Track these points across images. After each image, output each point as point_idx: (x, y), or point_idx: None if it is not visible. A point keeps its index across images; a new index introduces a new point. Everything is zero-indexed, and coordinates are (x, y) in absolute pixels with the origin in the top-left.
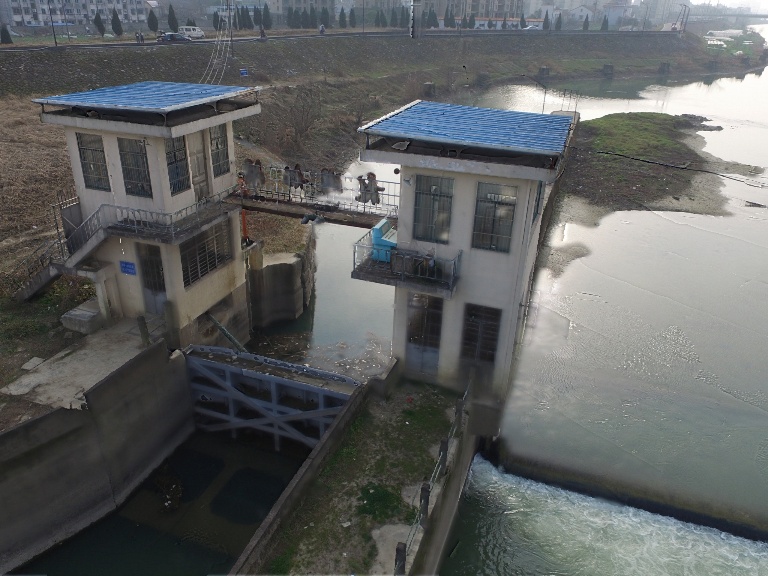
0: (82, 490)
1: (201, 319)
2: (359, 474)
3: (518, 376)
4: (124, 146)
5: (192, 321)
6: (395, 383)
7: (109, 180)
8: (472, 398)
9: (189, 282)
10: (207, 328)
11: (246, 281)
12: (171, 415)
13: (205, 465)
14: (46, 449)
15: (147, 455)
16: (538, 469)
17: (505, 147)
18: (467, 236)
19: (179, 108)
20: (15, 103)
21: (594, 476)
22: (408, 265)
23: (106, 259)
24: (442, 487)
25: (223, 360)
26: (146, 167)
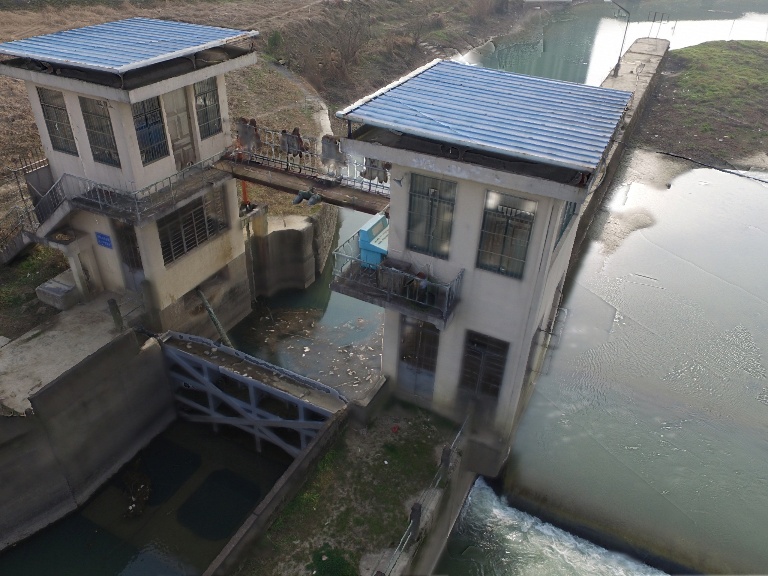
0: (34, 494)
1: (190, 295)
2: (316, 530)
3: (544, 378)
4: (86, 106)
5: (176, 300)
6: (383, 405)
7: (75, 143)
8: (469, 433)
9: (172, 258)
10: (196, 305)
11: (247, 249)
12: (145, 407)
13: (182, 460)
14: None
15: (115, 451)
16: (546, 506)
17: (520, 154)
18: (471, 253)
19: (139, 66)
20: (51, 17)
21: (611, 522)
22: (397, 281)
23: (82, 228)
24: (410, 558)
25: (201, 352)
26: (111, 132)
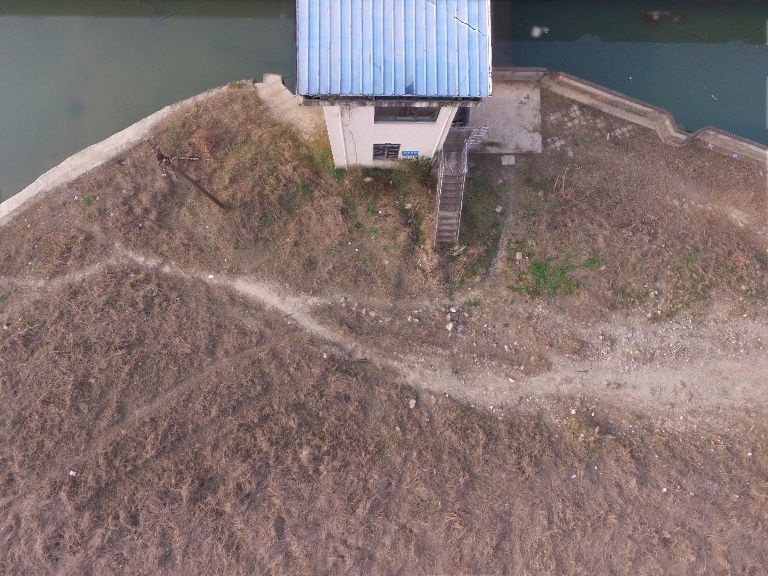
0: None
1: None
2: None
3: None
4: None
5: None
6: None
7: None
8: None
9: None
10: None
11: None
12: None
13: None
14: None
15: None
16: None
17: None
18: None
19: None
20: None
21: None
22: None
23: None
24: None
25: None
26: None
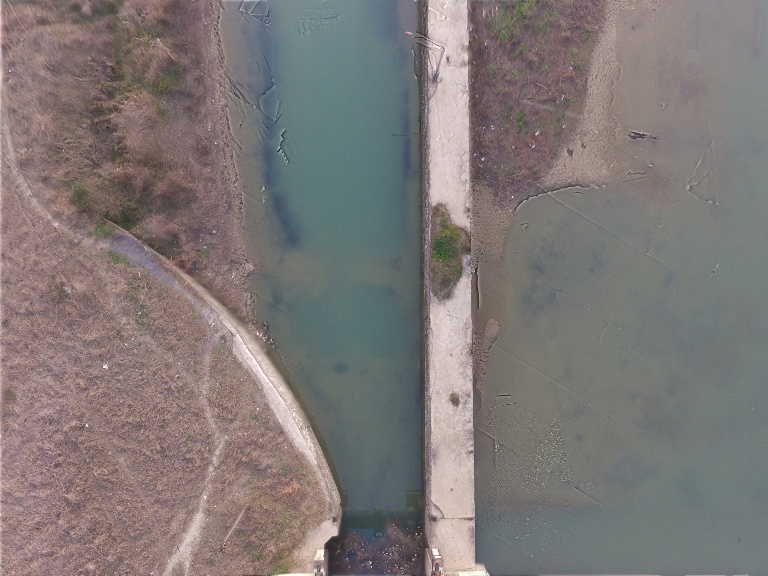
0: None
1: None
2: None
3: None
4: None
5: None
6: None
7: None
8: None
9: None
10: None
11: None
12: None
13: None
14: None
15: None
16: None
17: None
18: None
19: None
20: None
21: None
22: None
23: None
24: None
25: None
26: None
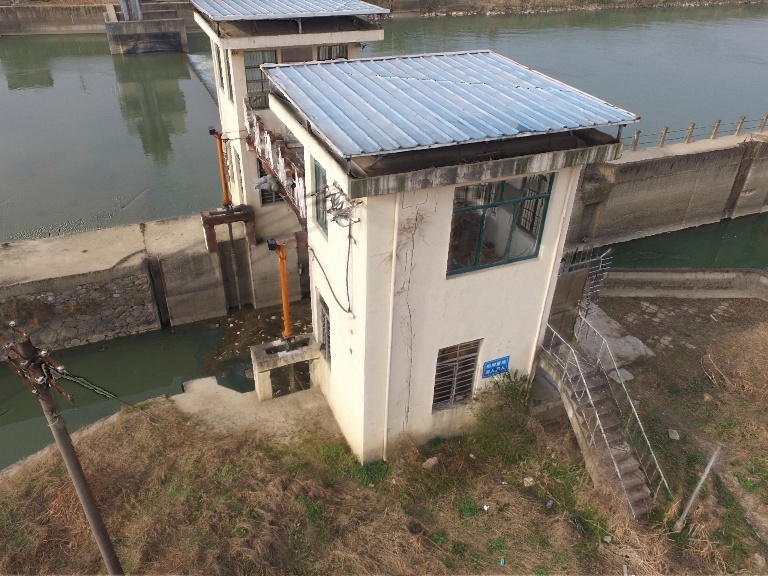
0: None
1: None
2: None
3: None
4: None
5: None
6: None
7: None
8: None
9: None
10: None
11: None
12: None
13: None
14: None
15: None
16: None
17: None
18: None
19: None
20: None
21: None
22: None
23: None
24: None
25: None
26: None
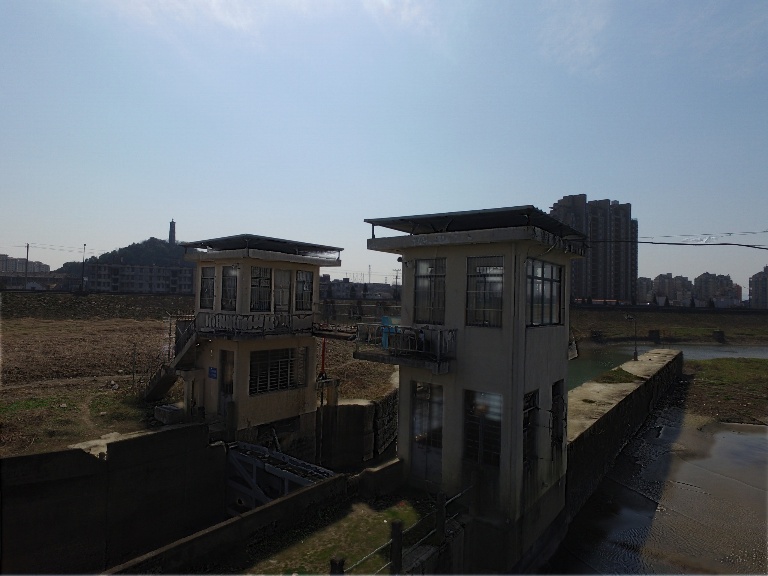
0: (74, 548)
1: (265, 432)
2: (296, 556)
3: (582, 547)
4: (225, 272)
5: (251, 427)
6: (395, 487)
7: (213, 300)
8: (475, 513)
9: (256, 391)
10: (267, 440)
11: (319, 413)
12: (197, 505)
13: None
14: (52, 487)
15: (158, 538)
16: None
17: None
18: (460, 313)
19: (260, 238)
20: None
21: None
22: None
23: (201, 366)
24: None
25: (256, 456)
26: (235, 286)
